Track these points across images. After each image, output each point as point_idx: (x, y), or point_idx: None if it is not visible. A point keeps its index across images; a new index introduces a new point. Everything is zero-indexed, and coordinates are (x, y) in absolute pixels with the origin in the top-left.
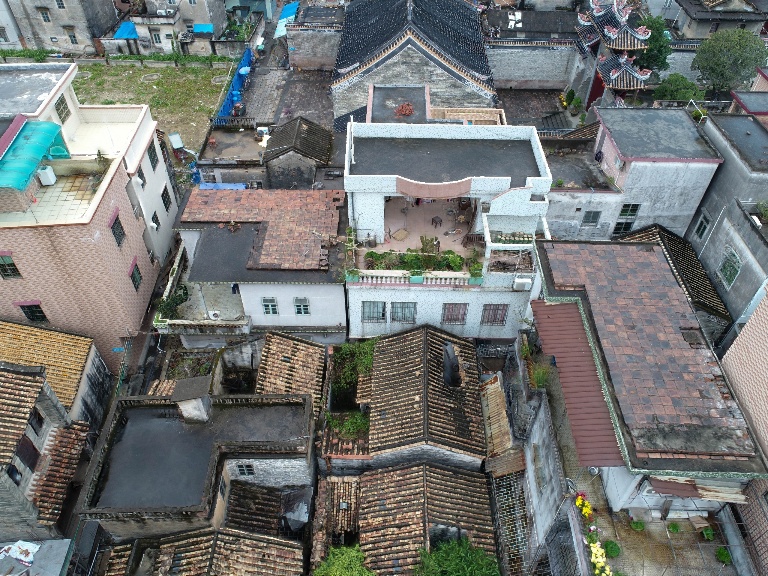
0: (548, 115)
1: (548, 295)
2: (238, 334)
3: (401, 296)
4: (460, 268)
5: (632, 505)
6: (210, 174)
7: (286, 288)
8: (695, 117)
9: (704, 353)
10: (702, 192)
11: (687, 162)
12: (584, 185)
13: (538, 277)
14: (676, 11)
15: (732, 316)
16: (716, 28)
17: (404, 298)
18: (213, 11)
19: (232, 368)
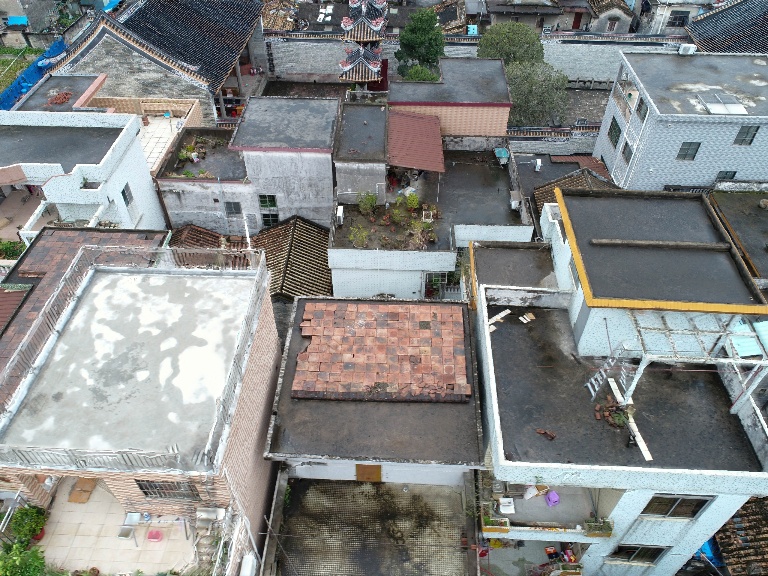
0: None
1: None
2: None
3: None
4: None
5: (7, 496)
6: None
7: None
8: None
9: None
10: (330, 183)
11: (298, 152)
12: (230, 176)
13: None
14: None
15: None
16: None
17: None
18: (31, 3)
19: None
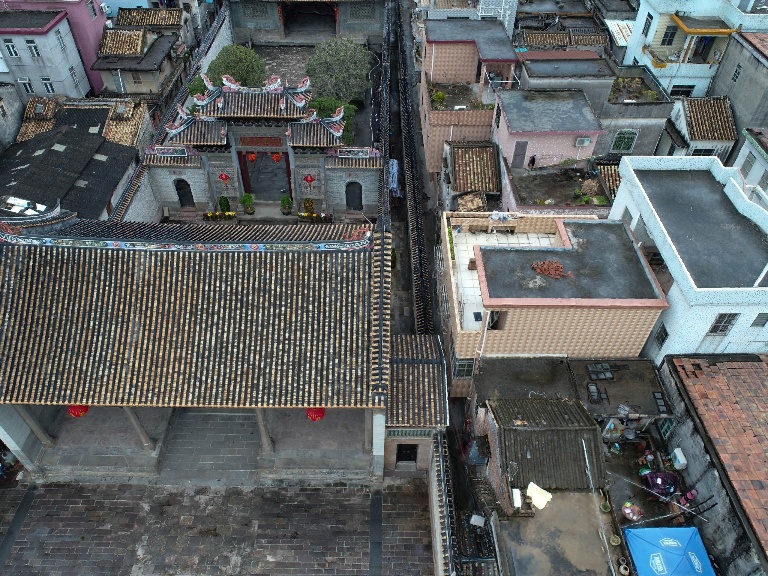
0: None
1: None
2: None
3: None
4: None
5: None
6: None
7: None
8: None
9: None
10: None
11: None
12: (567, 182)
13: None
14: (83, 82)
15: None
16: None
17: None
18: None
19: None
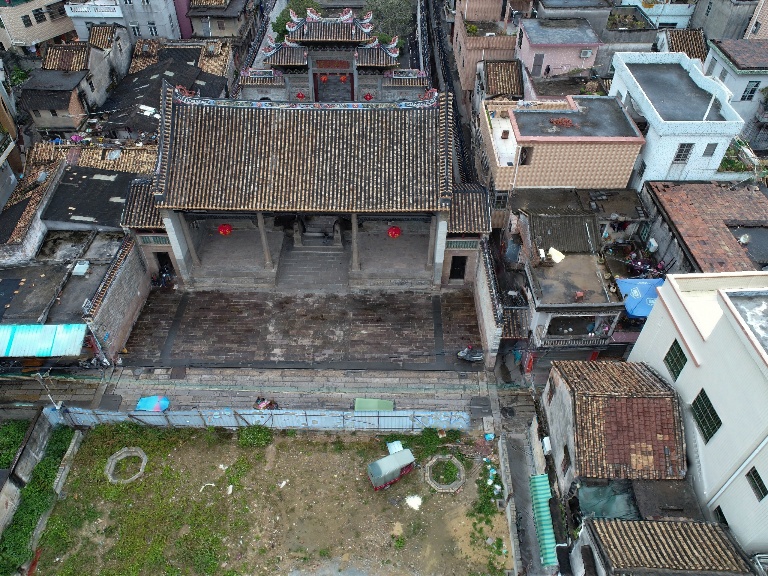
0: None
1: None
2: None
3: None
4: None
5: None
6: None
7: None
8: None
9: None
10: None
11: None
12: (574, 85)
13: (739, 88)
14: (176, 29)
15: None
16: None
17: None
18: None
19: None
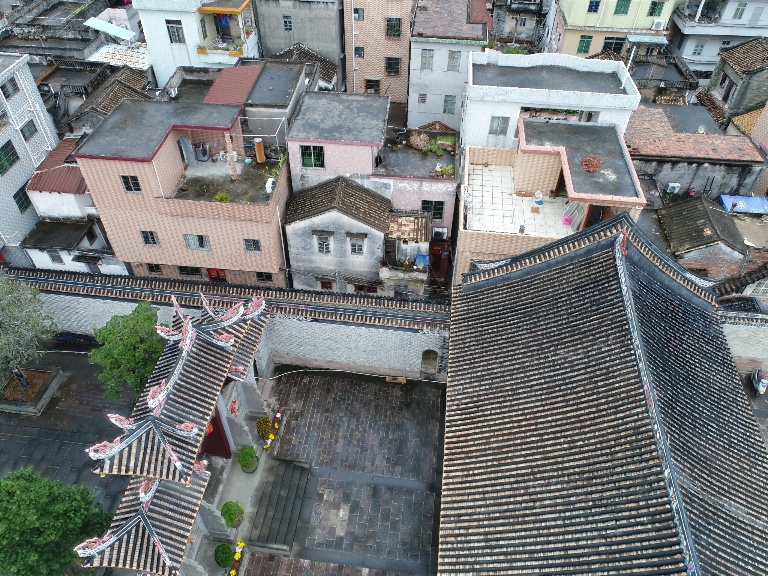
0: None
1: None
2: None
3: None
4: None
5: None
6: None
7: None
8: None
9: None
10: None
11: None
12: (400, 154)
13: None
14: None
15: None
16: None
17: None
18: None
19: None
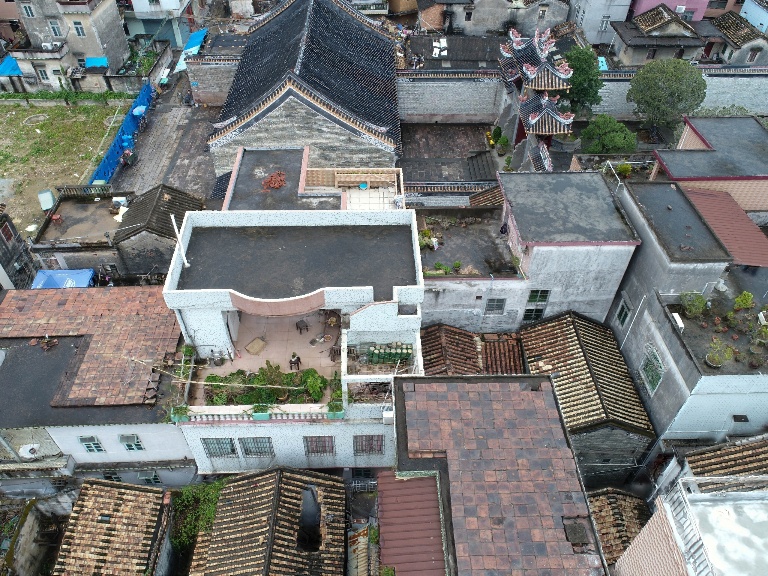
0: (474, 155)
1: (397, 469)
2: (58, 476)
3: (249, 432)
4: (320, 395)
5: None
6: (51, 258)
7: (105, 426)
8: (619, 173)
9: (590, 561)
10: (620, 275)
11: (598, 245)
12: (486, 266)
13: None
14: (613, 34)
15: (656, 429)
16: (653, 54)
17: (253, 433)
18: (108, 42)
19: (52, 518)
